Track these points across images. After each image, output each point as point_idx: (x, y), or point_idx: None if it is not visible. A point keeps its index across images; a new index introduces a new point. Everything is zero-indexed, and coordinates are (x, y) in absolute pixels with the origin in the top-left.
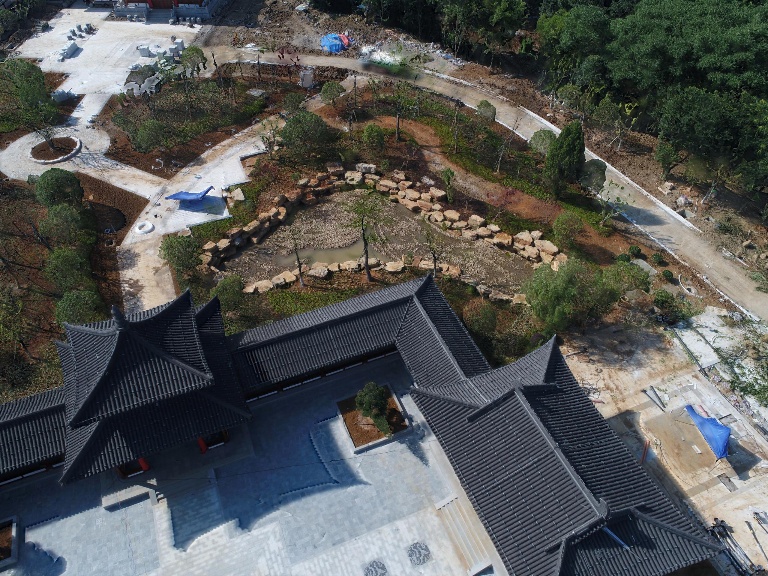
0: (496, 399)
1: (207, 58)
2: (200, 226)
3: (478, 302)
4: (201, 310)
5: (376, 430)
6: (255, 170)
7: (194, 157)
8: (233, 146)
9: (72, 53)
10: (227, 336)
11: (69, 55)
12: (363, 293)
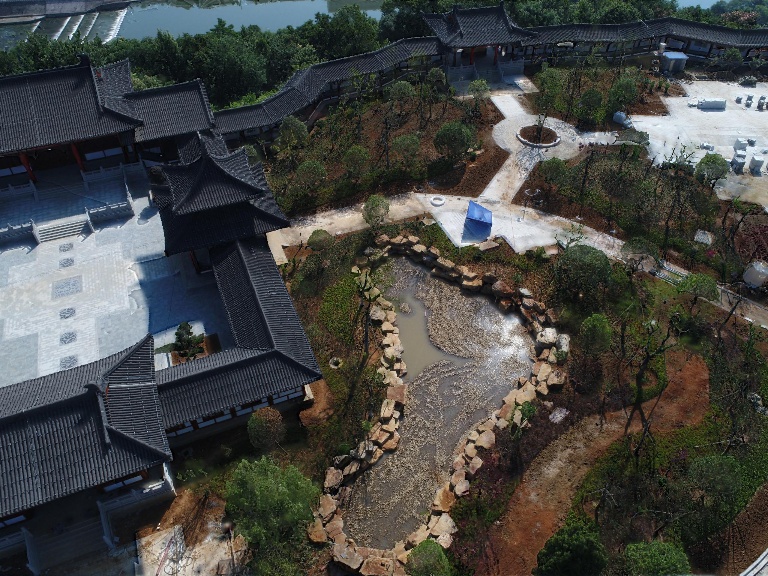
0: (99, 380)
1: (764, 190)
2: (439, 229)
3: (267, 412)
4: (271, 214)
5: (182, 360)
6: (531, 251)
7: (553, 212)
8: (582, 235)
9: (710, 108)
10: (267, 244)
11: (703, 107)
12: (347, 350)
